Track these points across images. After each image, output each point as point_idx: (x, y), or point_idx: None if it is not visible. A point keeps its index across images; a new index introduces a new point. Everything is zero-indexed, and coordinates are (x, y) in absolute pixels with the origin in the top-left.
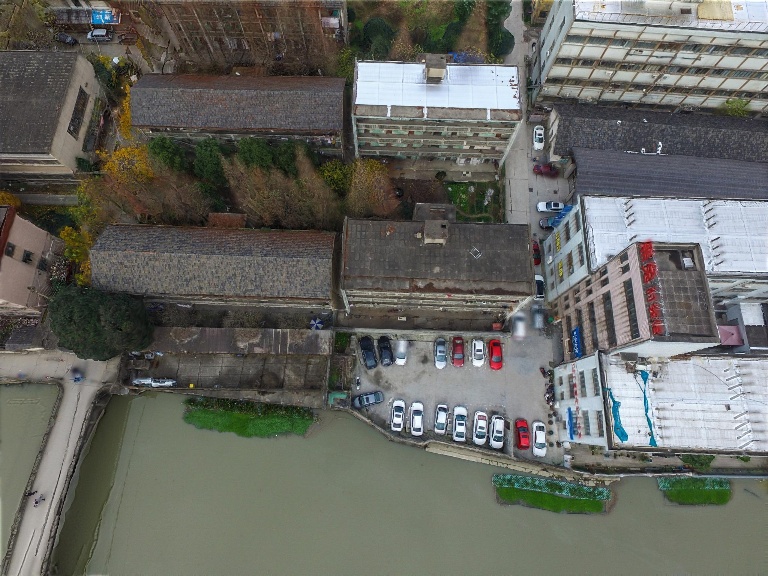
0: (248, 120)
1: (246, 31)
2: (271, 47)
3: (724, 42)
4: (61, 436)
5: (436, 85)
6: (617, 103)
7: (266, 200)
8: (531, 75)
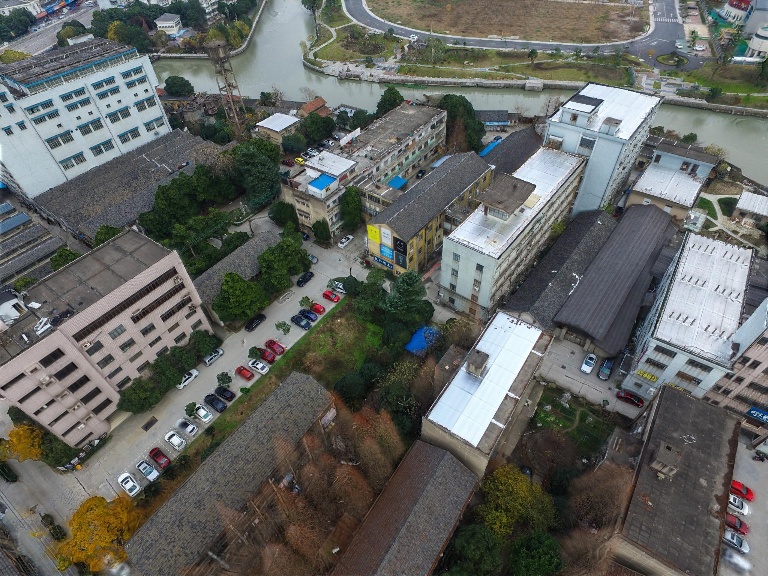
0: (416, 575)
1: (259, 508)
2: (283, 494)
3: (546, 208)
4: None
5: (489, 372)
6: (516, 277)
7: None
8: (455, 309)
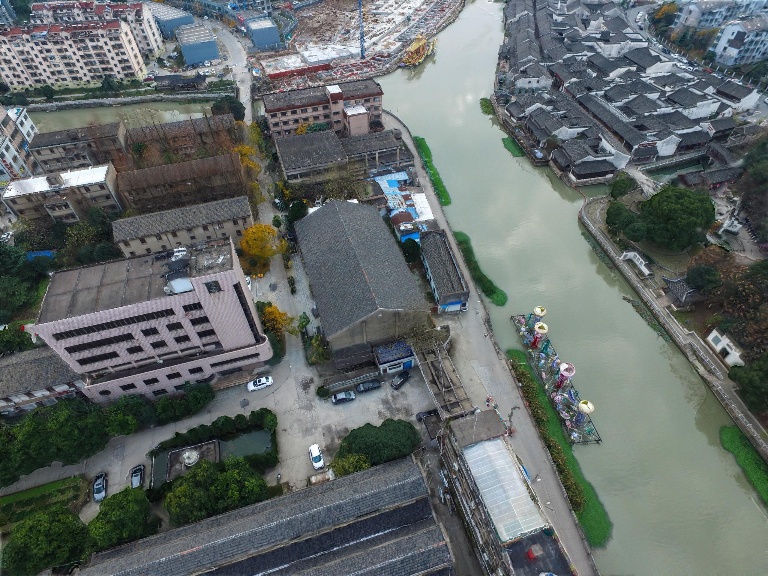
0: None
1: None
2: None
3: None
4: (248, 110)
5: None
6: None
7: (153, 130)
8: None
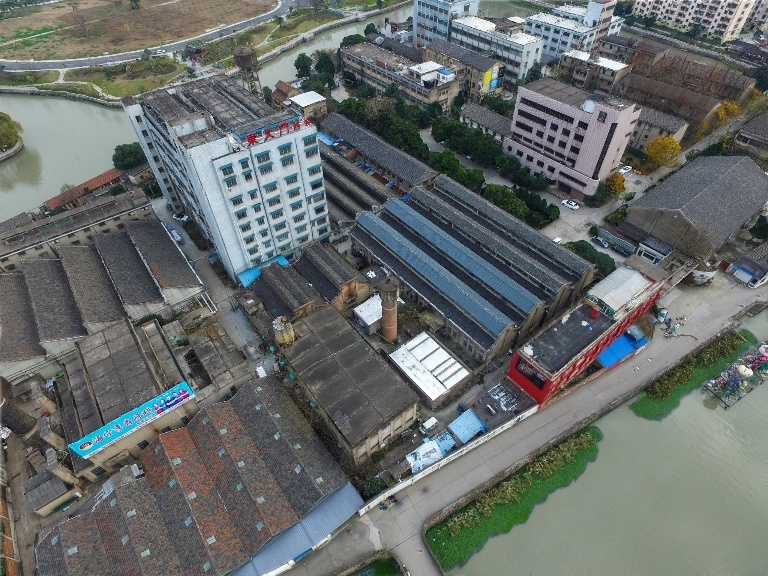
0: None
1: None
2: None
3: None
4: None
5: None
6: None
7: (682, 61)
8: None
